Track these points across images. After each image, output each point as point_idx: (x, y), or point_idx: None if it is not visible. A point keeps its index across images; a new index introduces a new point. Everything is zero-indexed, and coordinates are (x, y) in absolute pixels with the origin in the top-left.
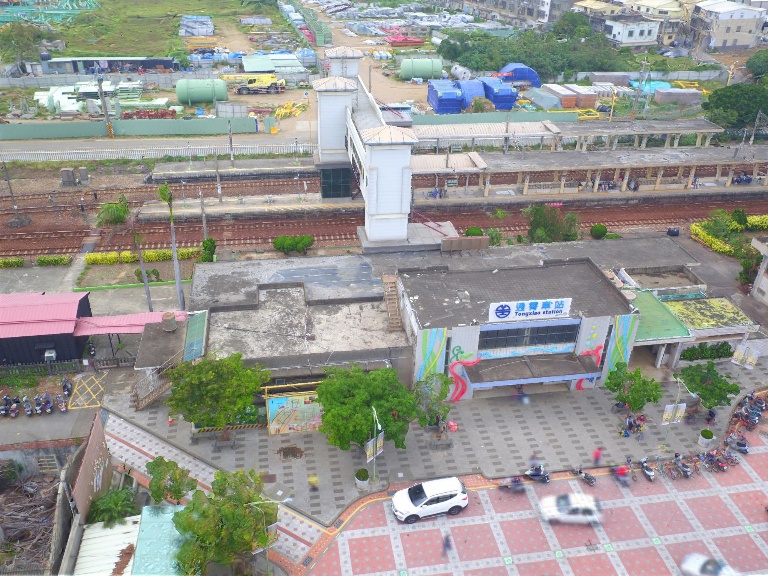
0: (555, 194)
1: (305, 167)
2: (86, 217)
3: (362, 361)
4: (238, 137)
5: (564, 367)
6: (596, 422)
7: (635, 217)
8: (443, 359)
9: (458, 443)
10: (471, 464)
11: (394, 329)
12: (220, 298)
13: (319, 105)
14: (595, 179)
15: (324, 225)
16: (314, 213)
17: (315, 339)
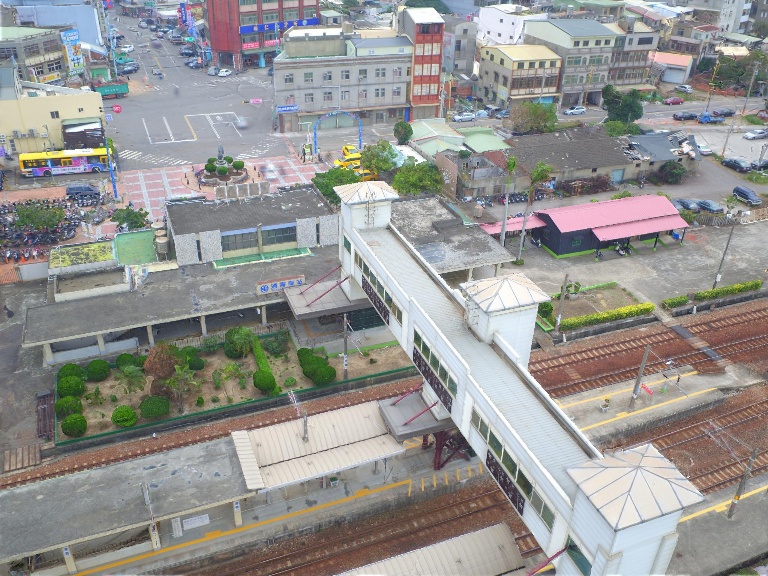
0: None
1: None
2: (761, 375)
3: None
4: None
5: None
6: None
7: None
8: None
9: None
10: None
11: None
12: (468, 236)
13: None
14: None
15: None
16: None
17: None
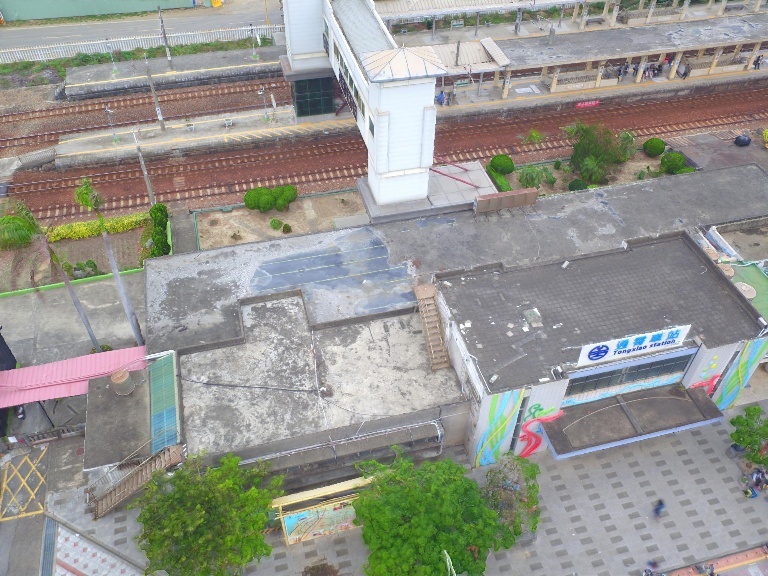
0: (589, 89)
1: (266, 63)
2: None
3: (403, 426)
4: (171, 15)
5: (672, 410)
6: (711, 475)
7: (690, 117)
8: (515, 419)
9: (541, 532)
10: (564, 569)
11: (438, 367)
12: (188, 322)
13: None
14: (639, 66)
15: (304, 157)
16: (289, 139)
17: (333, 394)
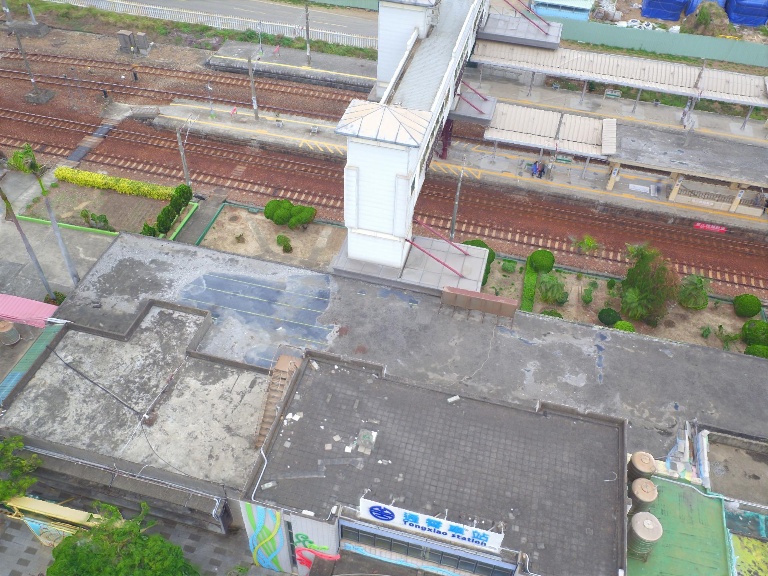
0: (720, 211)
1: None
2: (108, 105)
3: (187, 488)
4: (353, 14)
5: None
6: None
7: None
8: (284, 538)
9: None
10: None
11: None
12: (106, 302)
13: (379, 18)
14: None
15: None
16: None
17: (152, 425)
